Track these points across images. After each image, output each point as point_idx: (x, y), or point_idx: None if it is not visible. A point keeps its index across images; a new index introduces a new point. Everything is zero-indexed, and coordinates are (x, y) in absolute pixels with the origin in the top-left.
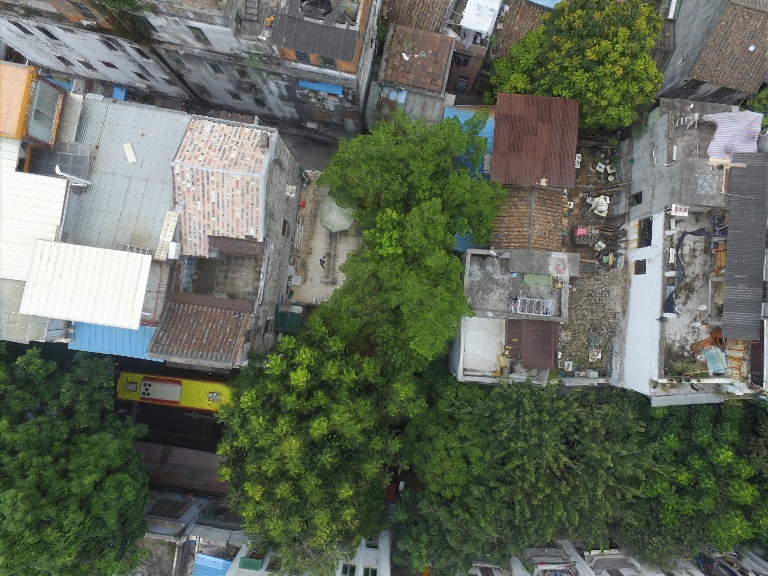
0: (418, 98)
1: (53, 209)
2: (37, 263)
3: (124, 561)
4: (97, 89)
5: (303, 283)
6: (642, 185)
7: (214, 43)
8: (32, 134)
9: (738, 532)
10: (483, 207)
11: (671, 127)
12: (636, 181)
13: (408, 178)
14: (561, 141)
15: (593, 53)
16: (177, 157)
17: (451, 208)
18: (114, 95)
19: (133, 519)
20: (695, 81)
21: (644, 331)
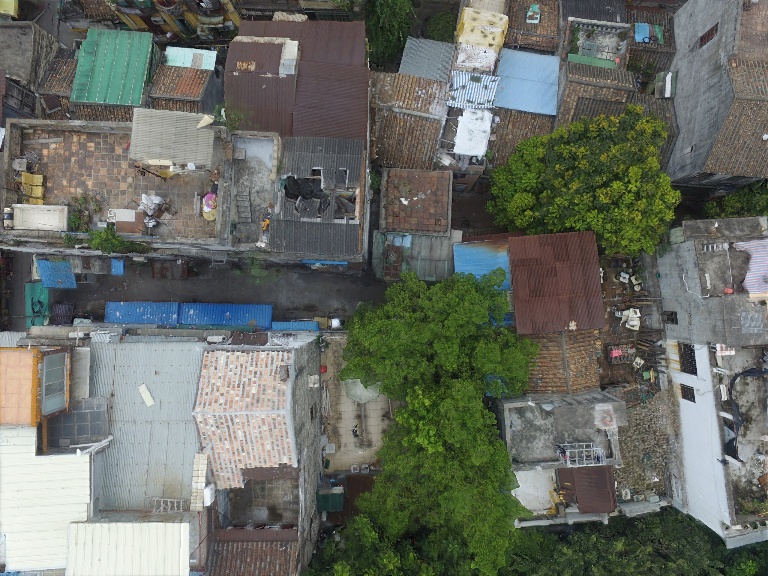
0: (424, 240)
1: (80, 487)
2: (73, 550)
3: None
4: (95, 263)
5: (338, 450)
6: (675, 306)
7: (211, 248)
8: (46, 412)
9: None
10: (516, 373)
11: (700, 257)
12: (667, 298)
13: (434, 361)
14: (584, 279)
15: (606, 197)
16: (197, 405)
17: None
18: (112, 266)
19: None
20: None
21: (704, 465)
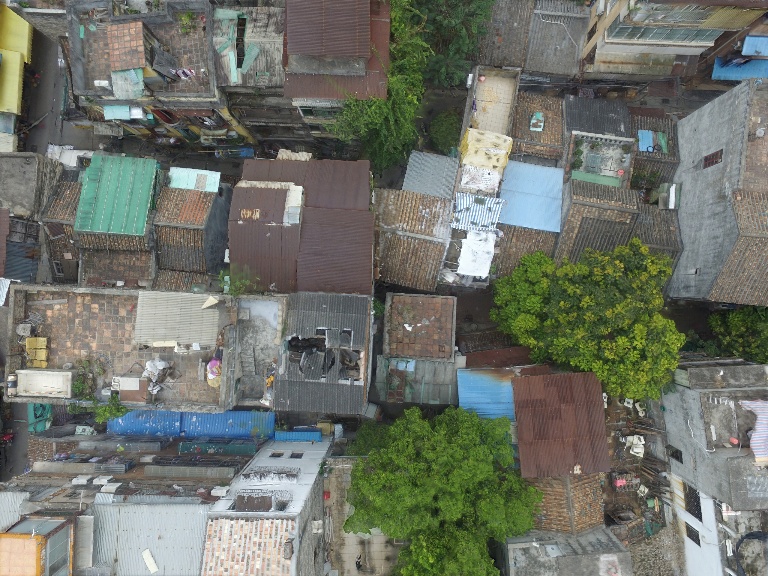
0: (428, 365)
1: None
2: None
3: None
4: None
5: None
6: (680, 445)
7: None
8: None
9: None
10: (521, 526)
11: (705, 410)
12: (672, 434)
13: (439, 517)
14: (588, 421)
15: (611, 352)
16: None
17: None
18: None
19: None
20: None
21: None
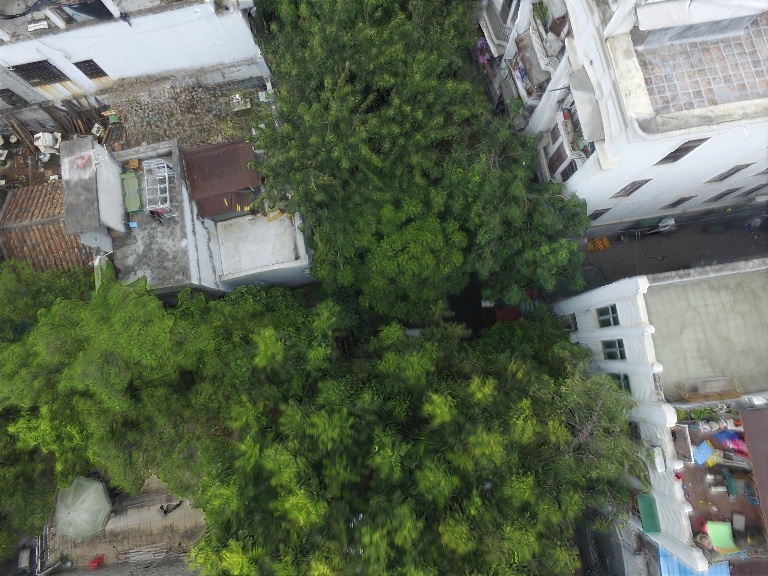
0: None
1: None
2: None
3: None
4: None
5: None
6: None
7: None
8: None
9: None
10: None
11: None
12: None
13: None
14: None
15: None
16: None
17: None
18: None
19: None
20: None
21: (165, 42)
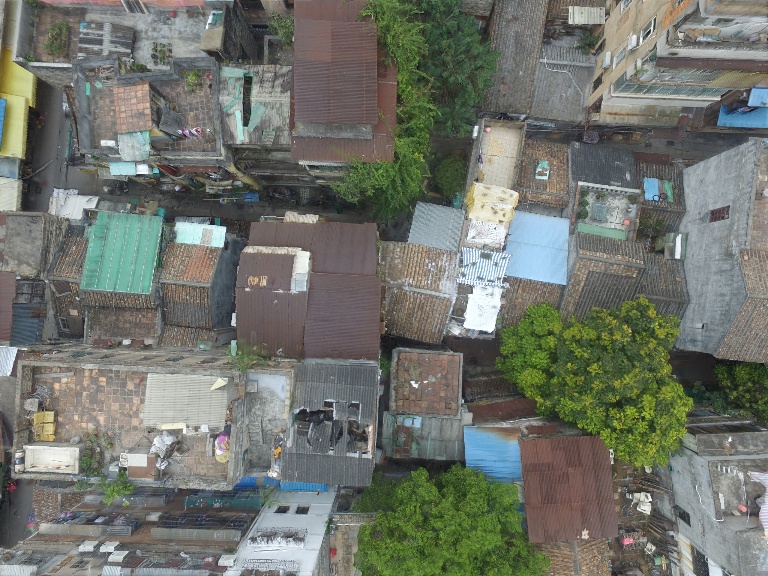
0: (434, 421)
1: None
2: None
3: None
4: None
5: None
6: (688, 508)
7: None
8: None
9: None
10: None
11: (714, 480)
12: (679, 495)
13: None
14: (596, 485)
15: (619, 422)
16: None
17: None
18: None
19: None
20: None
21: None
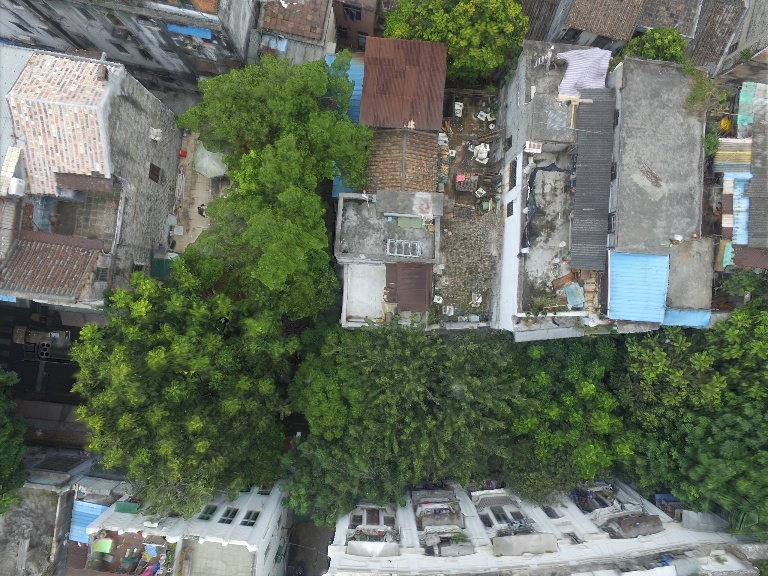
0: (299, 46)
1: None
2: None
3: (8, 513)
4: None
5: (186, 233)
6: (512, 129)
7: None
8: None
9: (592, 457)
10: (345, 147)
11: (528, 67)
12: (509, 126)
13: (266, 117)
14: (429, 84)
15: None
16: (12, 90)
17: (320, 151)
18: None
19: (5, 466)
20: (573, 30)
21: (511, 270)
